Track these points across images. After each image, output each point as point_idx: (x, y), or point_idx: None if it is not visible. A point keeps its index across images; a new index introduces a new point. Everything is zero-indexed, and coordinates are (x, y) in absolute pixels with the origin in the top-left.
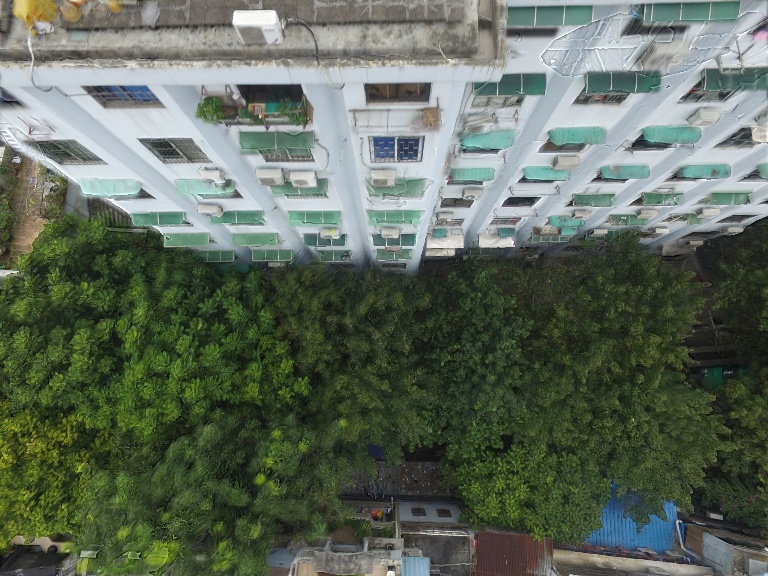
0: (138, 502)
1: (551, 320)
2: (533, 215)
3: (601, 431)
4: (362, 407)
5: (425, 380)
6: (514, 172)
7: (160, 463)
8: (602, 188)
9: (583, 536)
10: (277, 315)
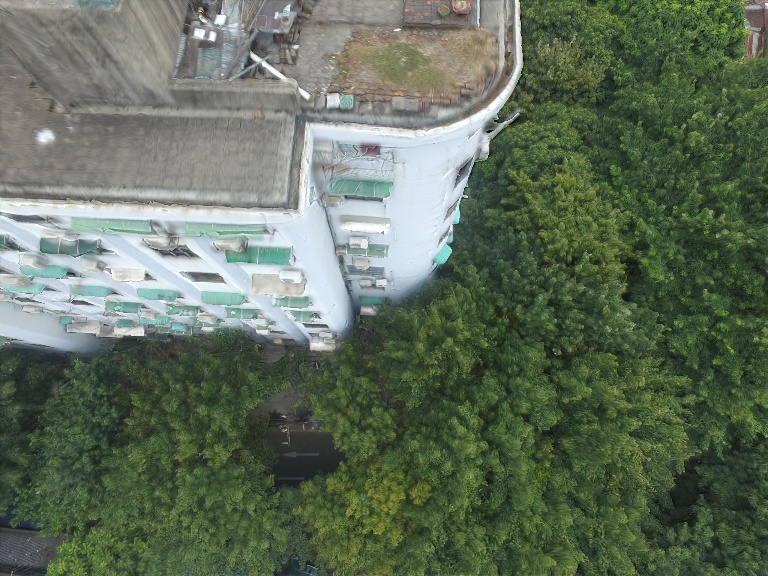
0: None
1: (133, 409)
2: (101, 314)
3: (162, 519)
4: None
5: (16, 458)
6: None
7: None
8: (121, 298)
9: None
10: None
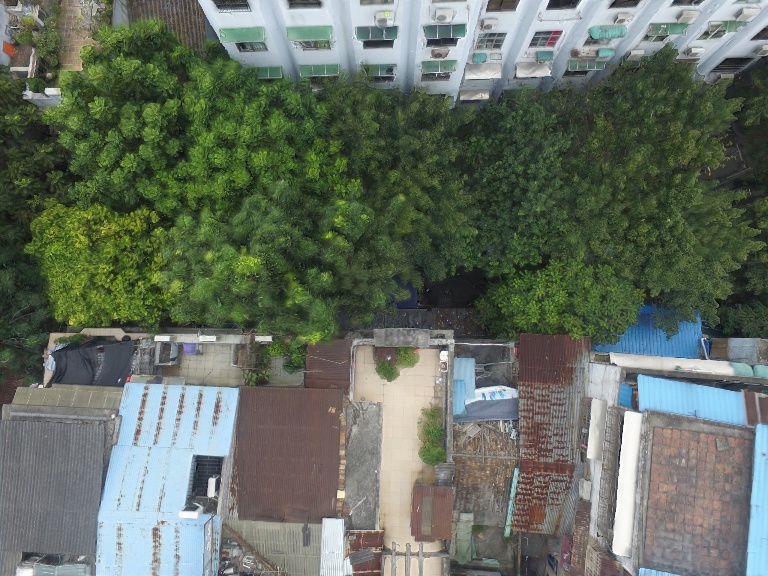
0: (224, 236)
1: (590, 134)
2: (577, 18)
3: (636, 239)
4: (413, 204)
5: None
6: None
7: (238, 214)
8: None
9: (619, 331)
10: (332, 111)
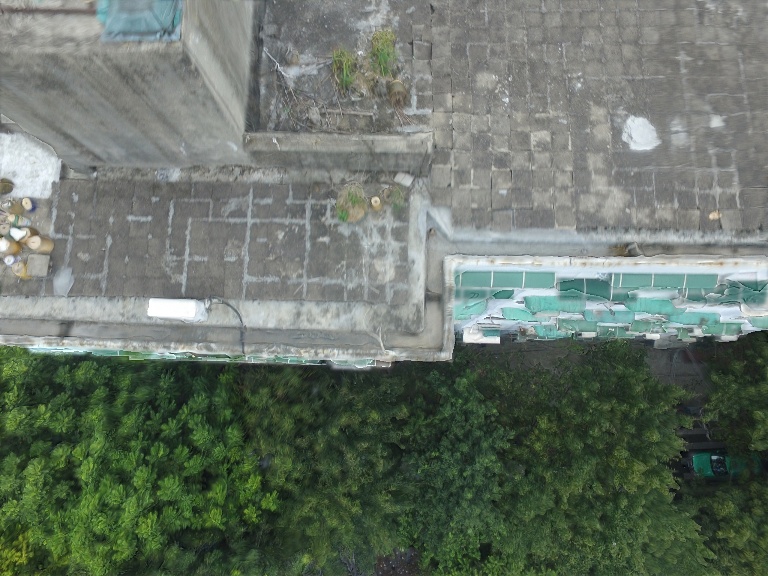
0: None
1: (533, 430)
2: None
3: (582, 549)
4: (331, 527)
5: (401, 486)
6: (493, 309)
7: None
8: None
9: None
10: (245, 432)
